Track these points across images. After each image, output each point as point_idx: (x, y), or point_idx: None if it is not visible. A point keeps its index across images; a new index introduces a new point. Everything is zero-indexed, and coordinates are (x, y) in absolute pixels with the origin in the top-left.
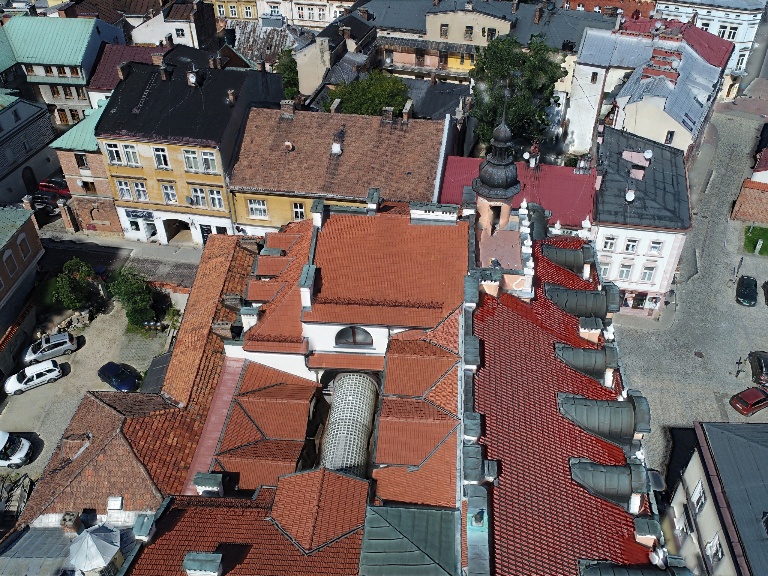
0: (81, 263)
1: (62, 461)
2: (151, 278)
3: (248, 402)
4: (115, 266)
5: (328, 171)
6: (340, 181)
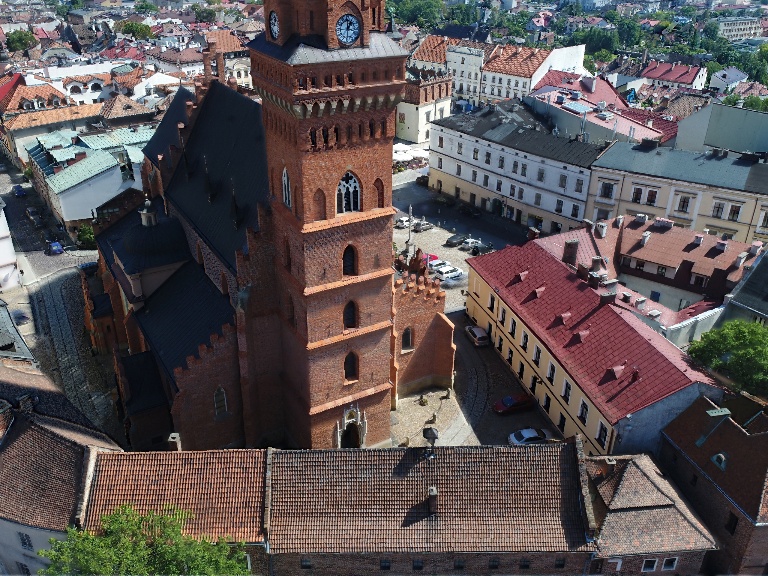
0: None
1: (133, 111)
2: (8, 187)
3: None
4: (5, 195)
5: None
6: None
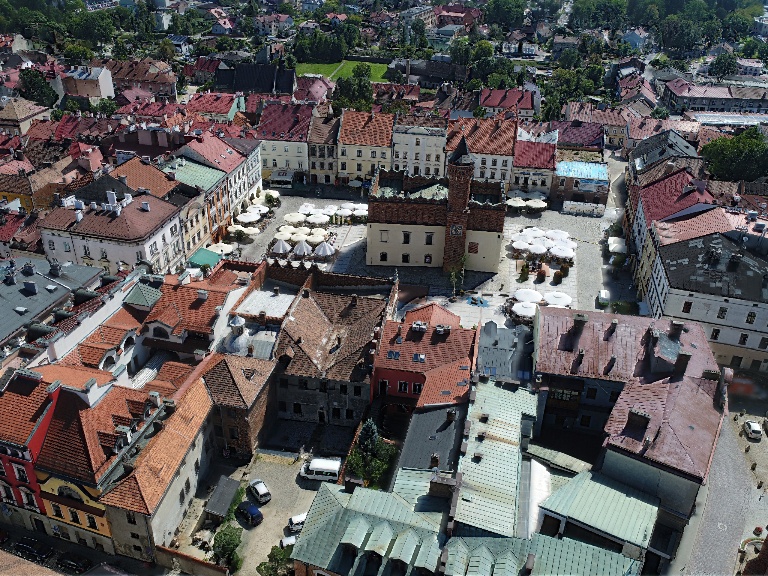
0: (266, 572)
1: None
2: None
3: (174, 388)
4: None
5: (10, 568)
6: (7, 561)
